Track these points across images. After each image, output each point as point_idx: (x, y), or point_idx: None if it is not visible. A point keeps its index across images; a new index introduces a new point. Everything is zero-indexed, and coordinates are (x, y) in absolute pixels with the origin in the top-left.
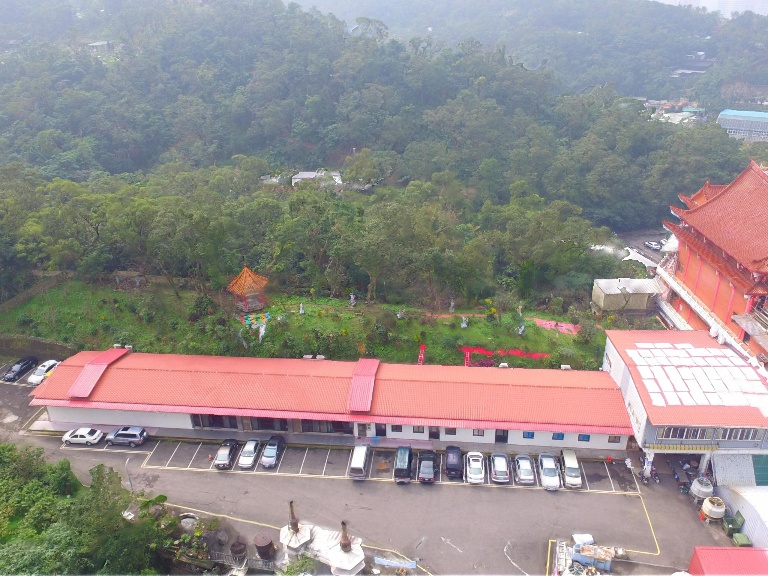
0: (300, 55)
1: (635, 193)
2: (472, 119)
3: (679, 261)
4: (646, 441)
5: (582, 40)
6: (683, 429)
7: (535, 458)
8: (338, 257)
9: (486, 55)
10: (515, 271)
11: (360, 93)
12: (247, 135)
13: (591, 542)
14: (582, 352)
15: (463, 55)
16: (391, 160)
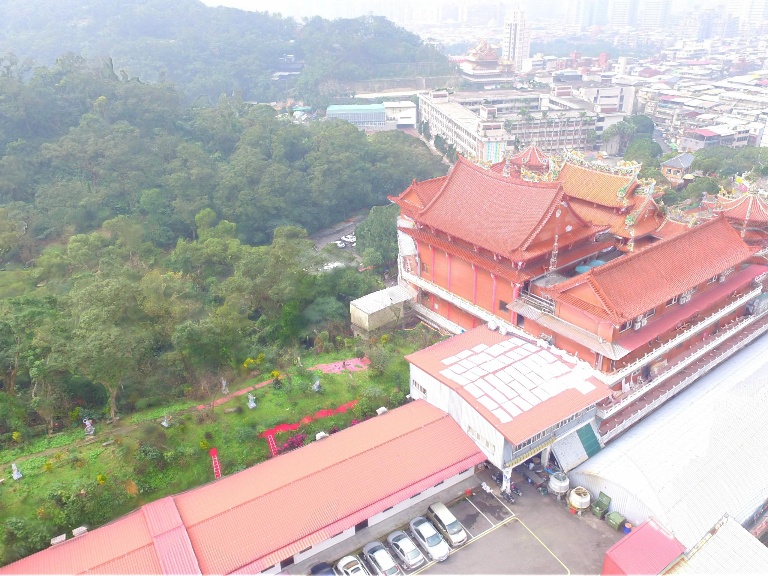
0: None
1: (306, 198)
2: (110, 147)
3: (422, 262)
4: (505, 461)
5: (178, 49)
6: None
7: (405, 529)
8: (43, 375)
9: (94, 71)
10: (240, 311)
11: None
12: None
13: None
14: (382, 386)
15: (64, 73)
16: (21, 214)
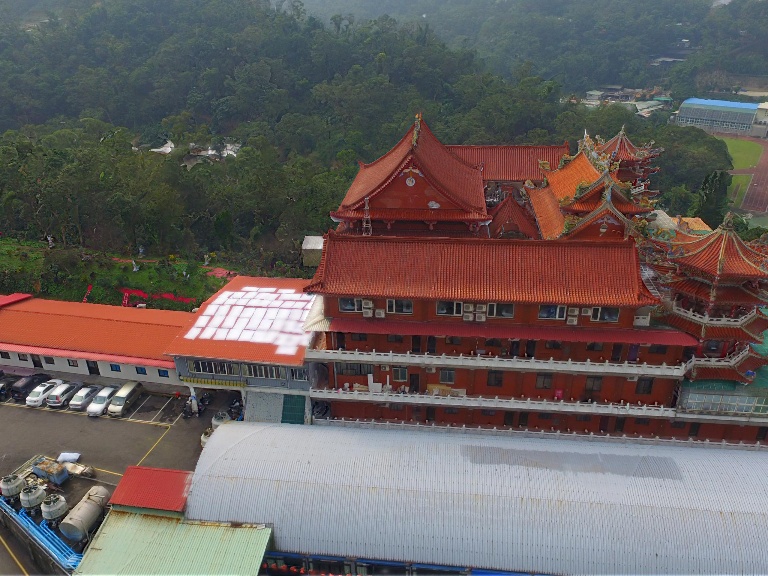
0: (209, 30)
1: None
2: (354, 93)
3: None
4: (181, 374)
5: (559, 26)
6: (210, 363)
7: None
8: None
9: (400, 33)
10: None
11: (250, 66)
12: (144, 105)
13: (73, 460)
14: None
15: (381, 33)
16: (259, 131)
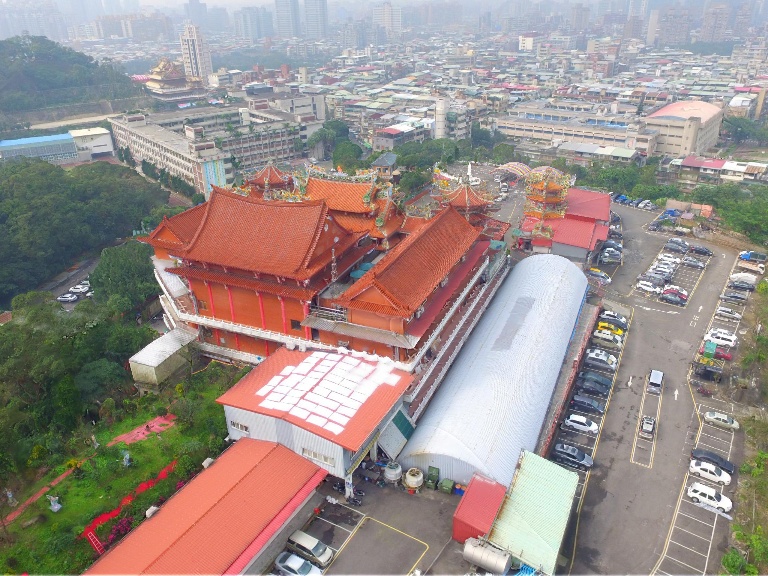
0: None
1: (14, 253)
2: None
3: (198, 300)
4: (346, 469)
5: None
6: None
7: (271, 571)
8: None
9: None
10: None
11: None
12: None
13: None
14: (195, 437)
15: None
16: None
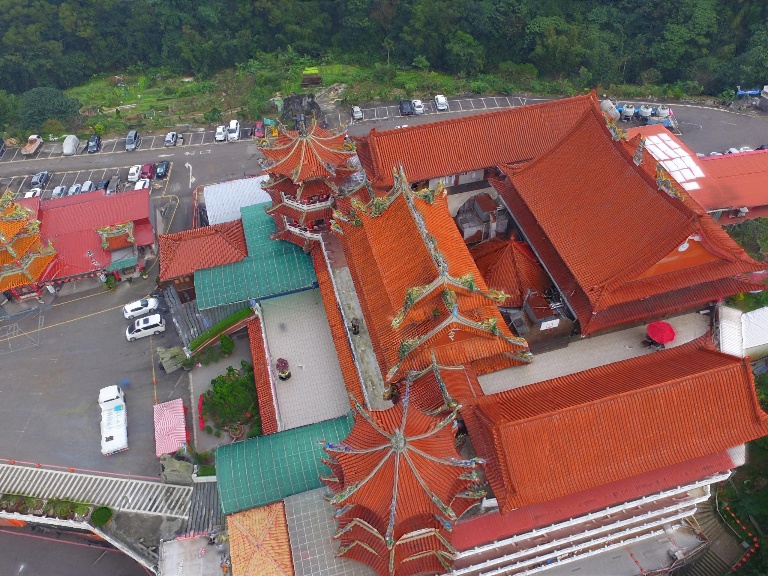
0: None
1: None
2: None
3: None
4: None
5: None
6: None
7: None
8: None
9: None
10: None
11: None
12: None
13: None
14: None
15: None
16: None
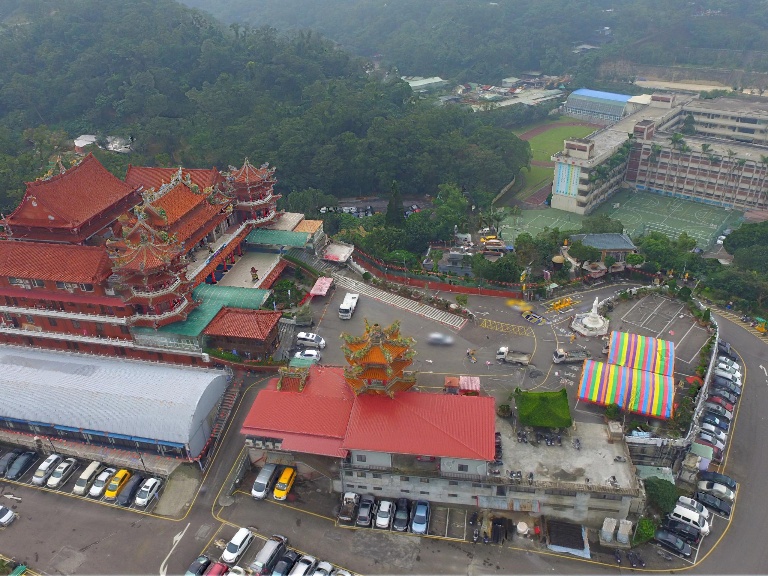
0: (121, 40)
1: (308, 167)
2: (213, 99)
3: None
4: None
5: (490, 14)
6: None
7: None
8: None
9: (279, 40)
10: None
11: None
12: (64, 105)
13: None
14: None
15: None
16: (131, 131)
